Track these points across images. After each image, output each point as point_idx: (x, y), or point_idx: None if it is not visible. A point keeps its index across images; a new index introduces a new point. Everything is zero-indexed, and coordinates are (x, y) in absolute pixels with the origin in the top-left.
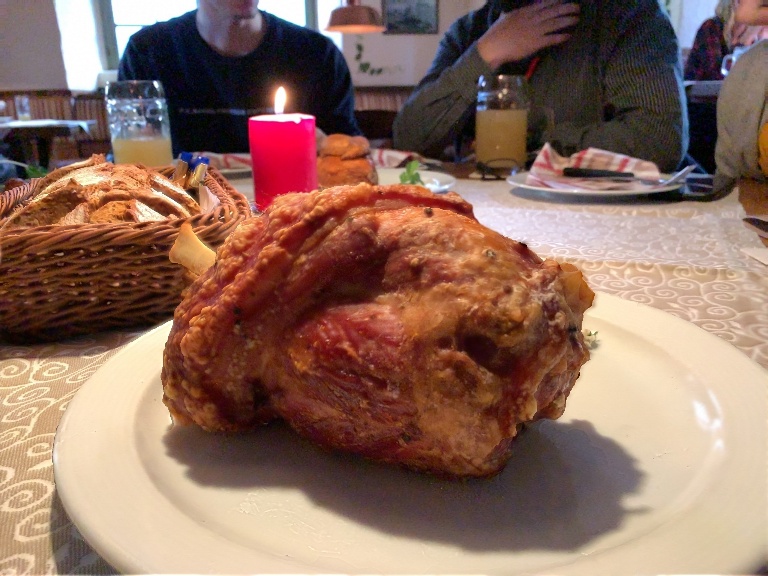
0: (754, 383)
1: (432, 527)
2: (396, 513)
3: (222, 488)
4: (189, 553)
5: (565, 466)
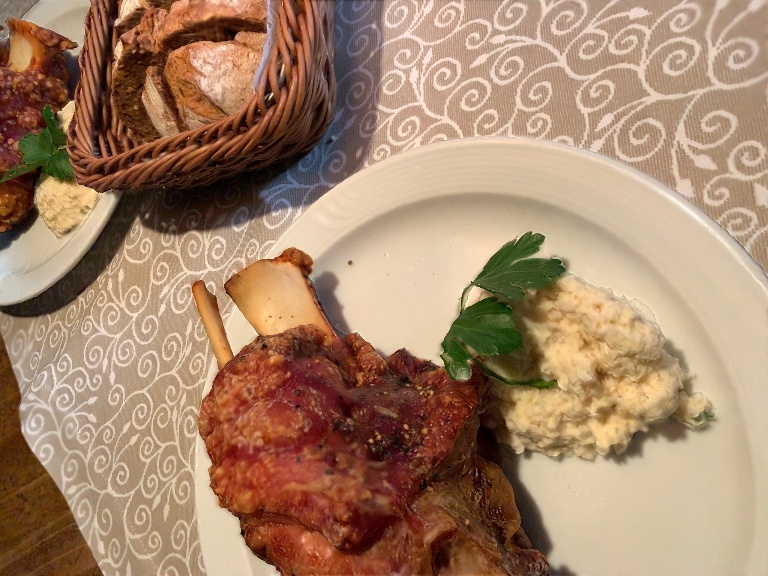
0: None
1: None
2: None
3: None
4: None
5: None
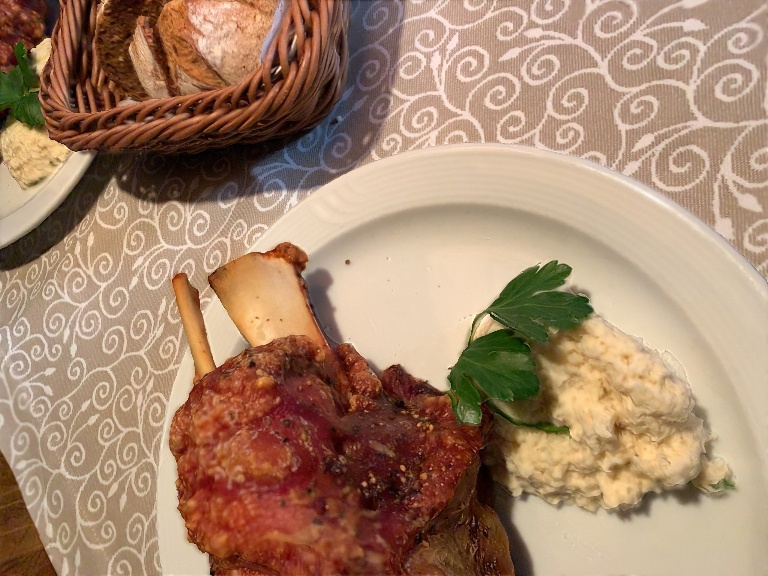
0: None
1: None
2: None
3: None
4: None
5: None
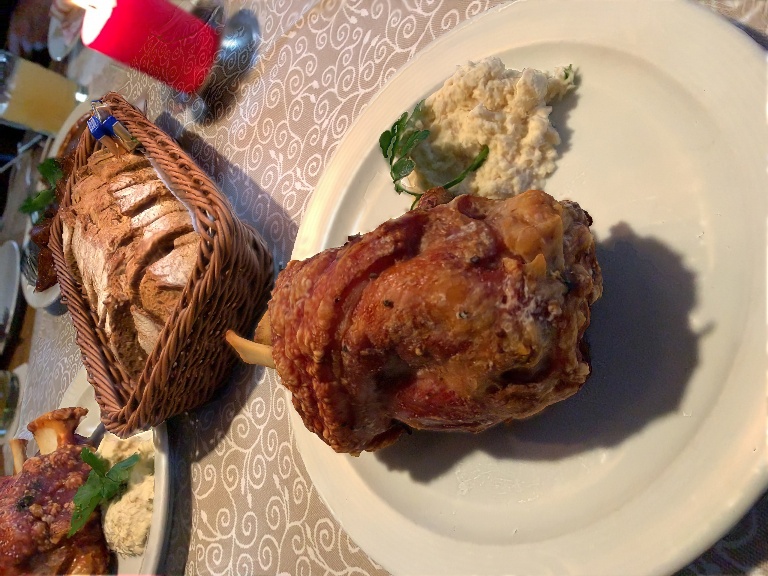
0: (752, 86)
1: (576, 437)
2: (548, 441)
3: (439, 478)
4: (471, 575)
5: (631, 298)
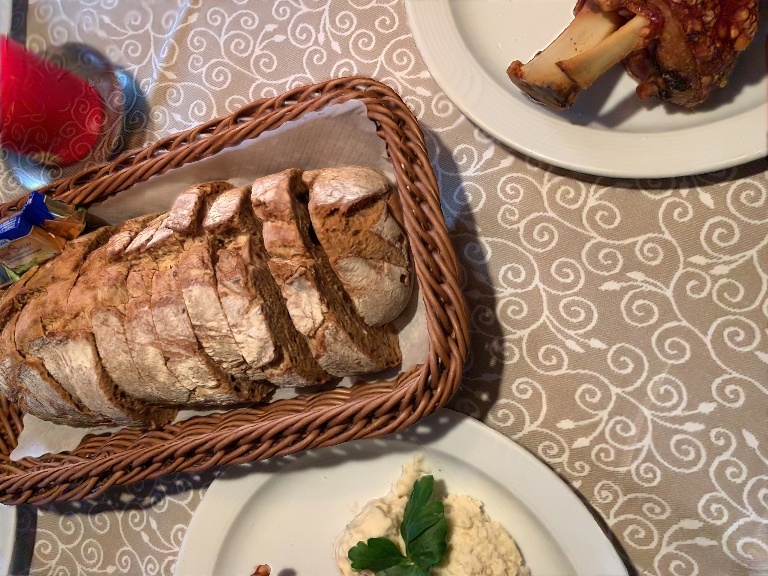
0: None
1: None
2: None
3: None
4: None
5: None
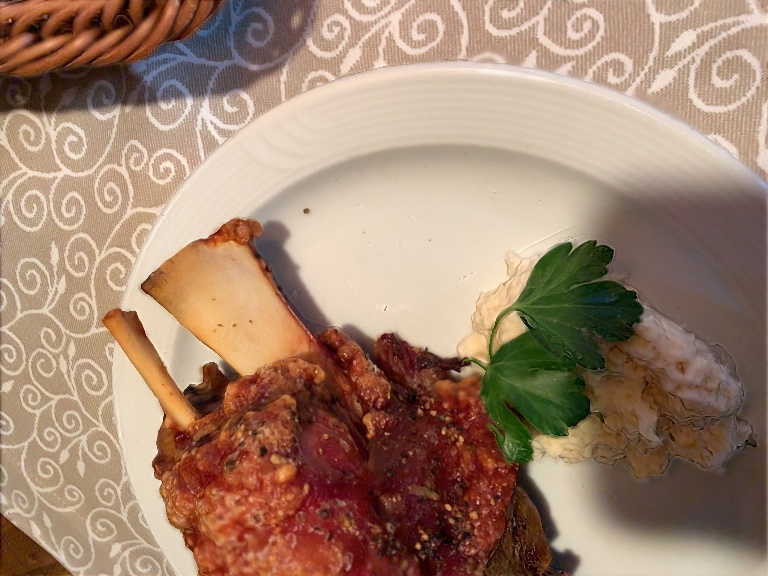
0: None
1: None
2: None
3: None
4: None
5: None
